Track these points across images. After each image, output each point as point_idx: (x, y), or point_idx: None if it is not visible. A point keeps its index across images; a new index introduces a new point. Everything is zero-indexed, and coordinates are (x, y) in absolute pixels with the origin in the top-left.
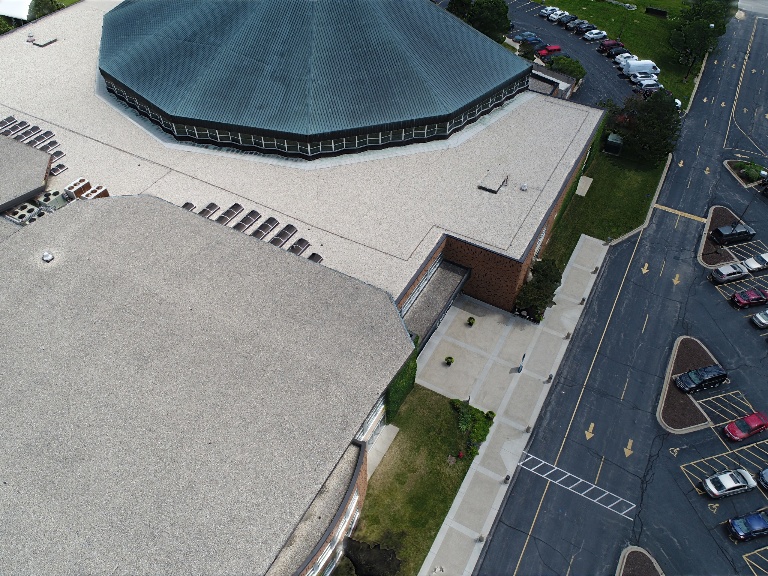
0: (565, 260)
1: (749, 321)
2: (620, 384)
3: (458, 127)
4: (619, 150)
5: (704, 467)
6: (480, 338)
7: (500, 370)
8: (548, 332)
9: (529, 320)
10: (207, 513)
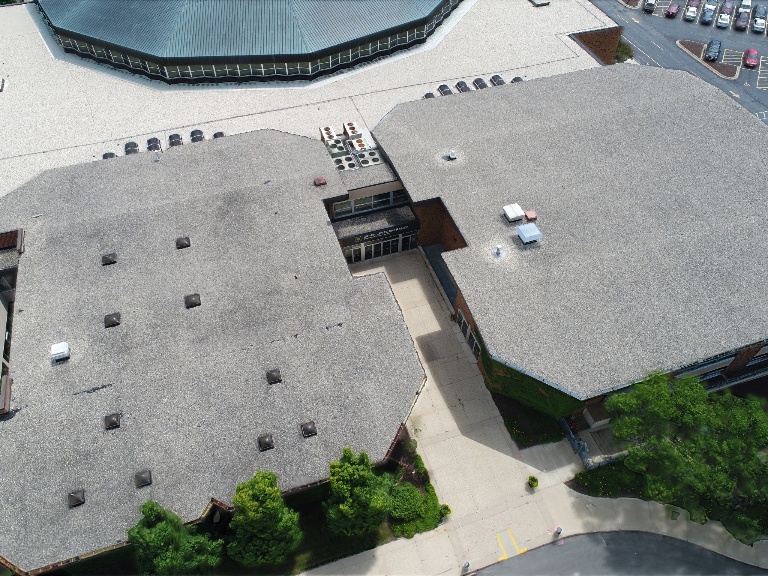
0: None
1: (685, 21)
2: None
3: None
4: None
5: (762, 82)
6: None
7: None
8: None
9: None
10: (765, 169)
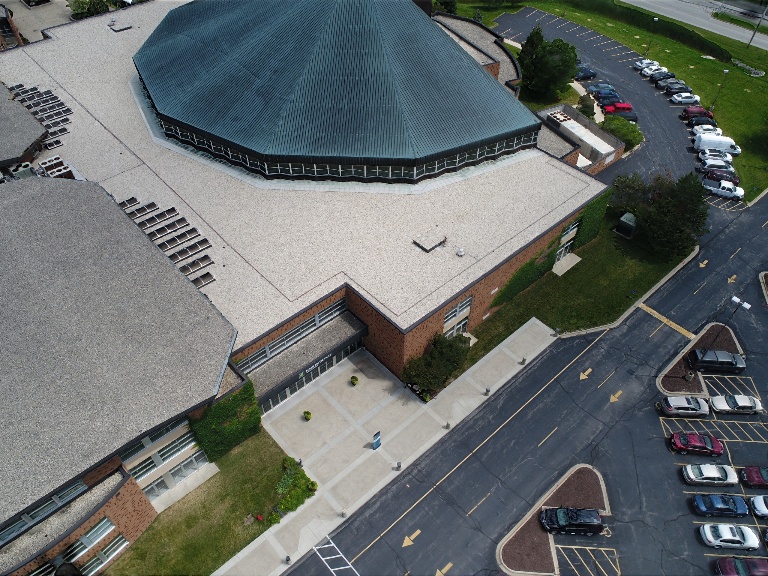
0: (496, 341)
1: (678, 470)
2: (477, 496)
3: (431, 174)
4: (631, 233)
5: None
6: (355, 401)
7: (355, 441)
8: (431, 415)
9: (418, 396)
10: None
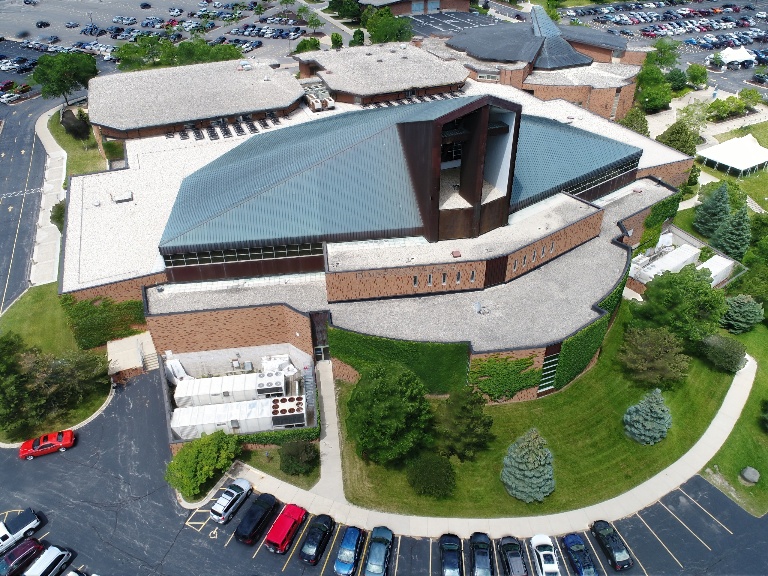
0: None
1: None
2: None
3: None
4: None
5: None
6: None
7: None
8: None
9: None
10: None
